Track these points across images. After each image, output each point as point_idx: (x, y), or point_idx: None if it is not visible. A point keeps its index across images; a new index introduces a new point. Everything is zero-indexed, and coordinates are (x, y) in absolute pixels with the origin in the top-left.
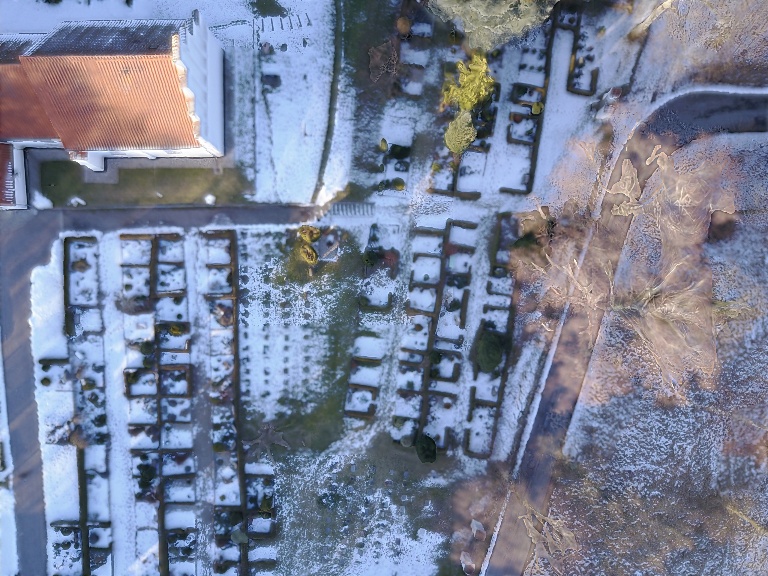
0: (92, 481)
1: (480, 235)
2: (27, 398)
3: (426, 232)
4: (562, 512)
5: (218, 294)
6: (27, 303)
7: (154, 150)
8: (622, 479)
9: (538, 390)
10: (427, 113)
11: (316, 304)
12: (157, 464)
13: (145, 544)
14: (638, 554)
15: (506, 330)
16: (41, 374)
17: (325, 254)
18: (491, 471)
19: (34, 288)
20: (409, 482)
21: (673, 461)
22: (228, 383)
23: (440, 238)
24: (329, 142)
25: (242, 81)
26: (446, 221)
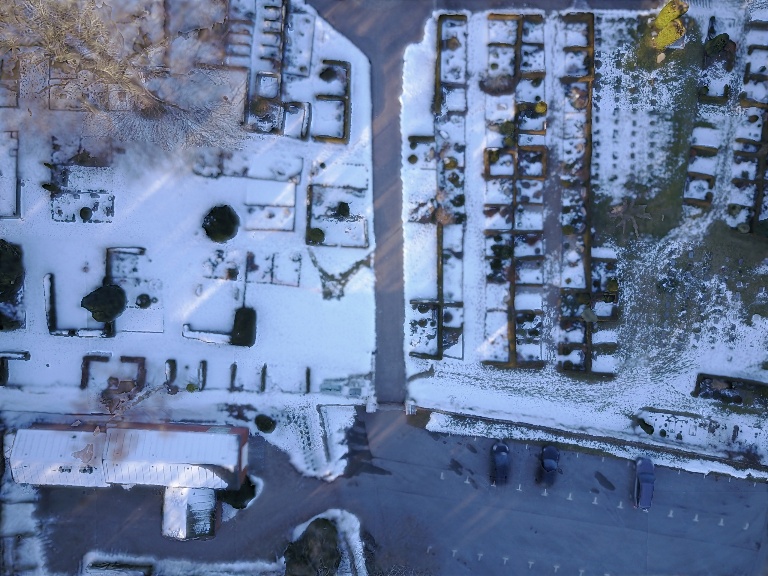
0: (447, 261)
1: None
2: (393, 176)
3: (763, 25)
4: None
5: (577, 75)
6: (399, 81)
7: None
8: None
9: None
10: None
11: (662, 91)
12: (509, 245)
13: (494, 325)
14: None
15: None
16: (408, 152)
17: None
18: None
19: (407, 66)
20: (744, 269)
21: None
22: (579, 166)
23: None
24: None
25: None
26: None
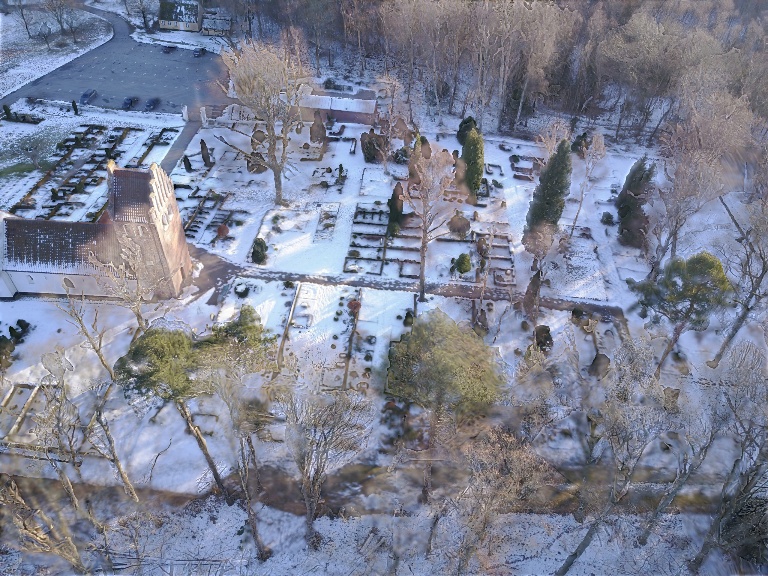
0: None
1: None
2: None
3: None
4: None
5: (24, 206)
6: None
7: None
8: None
9: None
10: None
11: None
12: None
13: (131, 140)
14: None
15: None
16: None
17: None
18: None
19: None
20: None
21: None
22: None
23: None
24: None
25: None
26: None
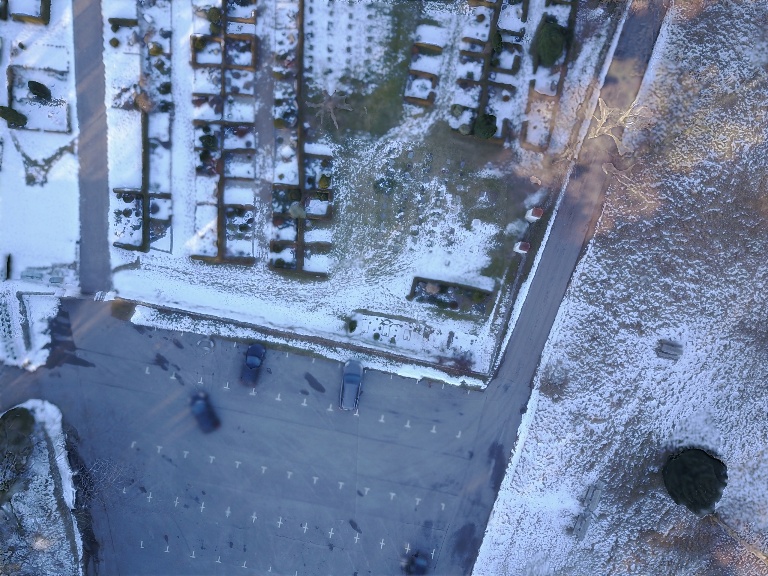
0: (155, 151)
1: None
2: (95, 59)
3: None
4: (617, 207)
5: None
6: None
7: None
8: (678, 175)
9: (597, 86)
10: None
11: None
12: (219, 137)
13: (204, 219)
14: (691, 251)
15: (567, 25)
16: (110, 34)
17: None
18: (547, 164)
19: None
20: (465, 172)
21: (730, 158)
22: (291, 58)
23: None
24: None
25: None
26: None
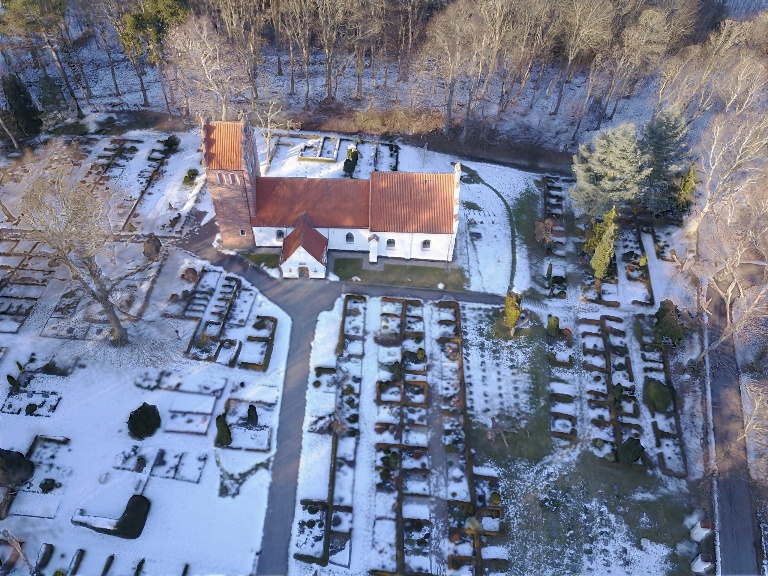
0: (340, 469)
1: (626, 327)
2: (299, 396)
3: (588, 320)
4: None
5: None
6: (312, 332)
7: (424, 234)
8: None
9: (709, 427)
10: (571, 264)
11: (518, 353)
12: None
13: (382, 534)
14: None
15: (666, 384)
16: (314, 379)
17: (520, 324)
18: (692, 488)
19: (319, 323)
20: (620, 495)
21: None
22: (456, 400)
23: (598, 326)
24: (514, 266)
25: (460, 232)
26: (600, 317)
